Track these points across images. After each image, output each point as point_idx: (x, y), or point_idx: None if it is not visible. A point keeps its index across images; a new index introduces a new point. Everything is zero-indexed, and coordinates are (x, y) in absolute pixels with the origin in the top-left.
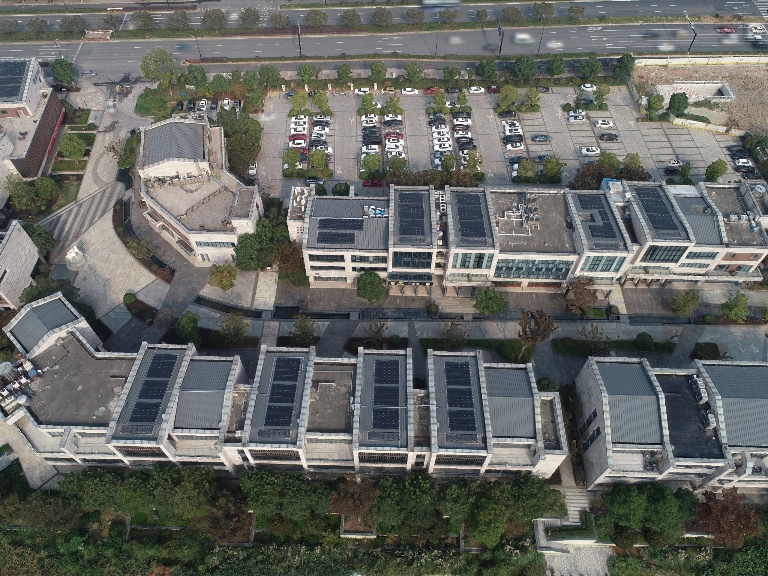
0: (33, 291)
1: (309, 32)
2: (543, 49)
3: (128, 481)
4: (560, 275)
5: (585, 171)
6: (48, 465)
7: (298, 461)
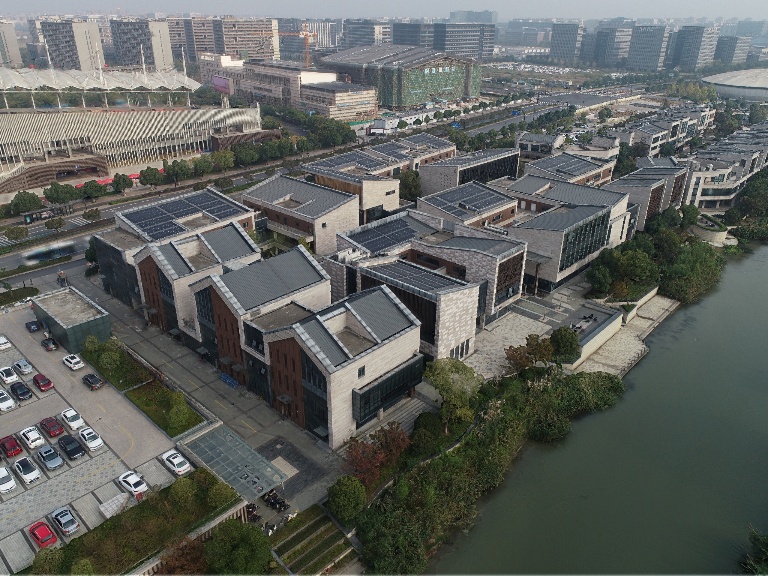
0: (627, 164)
1: (444, 136)
2: (528, 121)
3: (760, 178)
4: (692, 134)
5: (645, 115)
6: (721, 212)
7: (767, 161)
